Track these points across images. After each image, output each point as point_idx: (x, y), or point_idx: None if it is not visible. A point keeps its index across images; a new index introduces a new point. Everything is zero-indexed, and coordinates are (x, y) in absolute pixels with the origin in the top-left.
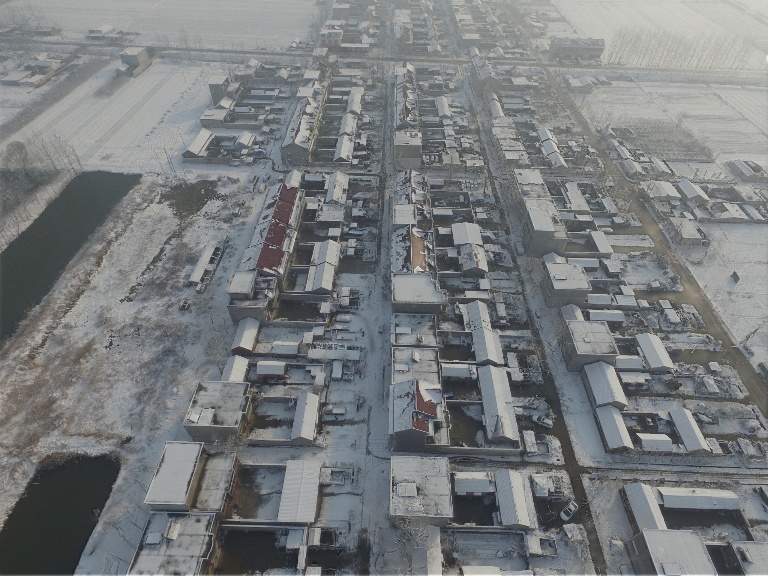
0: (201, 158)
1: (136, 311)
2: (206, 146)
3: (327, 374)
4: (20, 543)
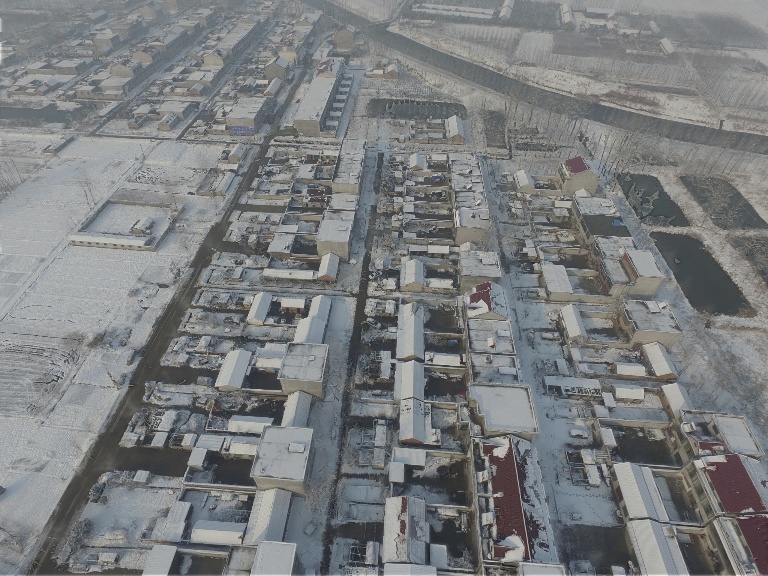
0: None
1: None
2: None
3: (571, 370)
4: (716, 282)
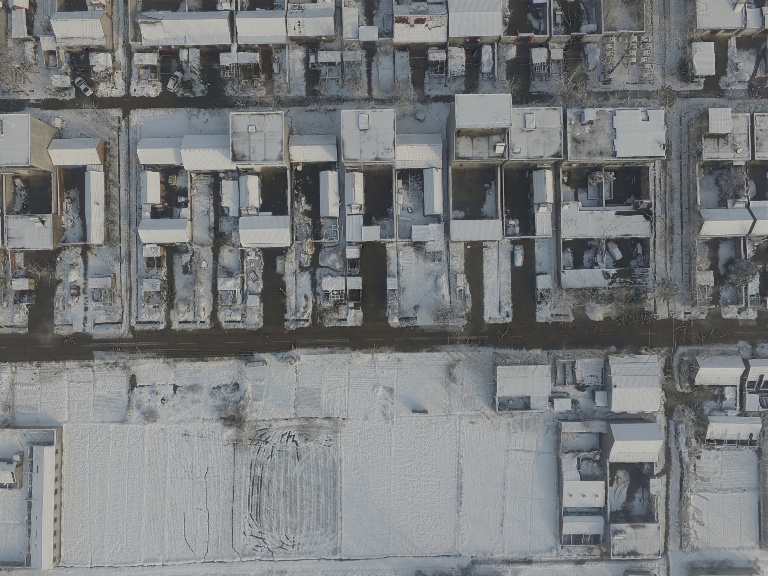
0: None
1: None
2: None
3: None
4: None
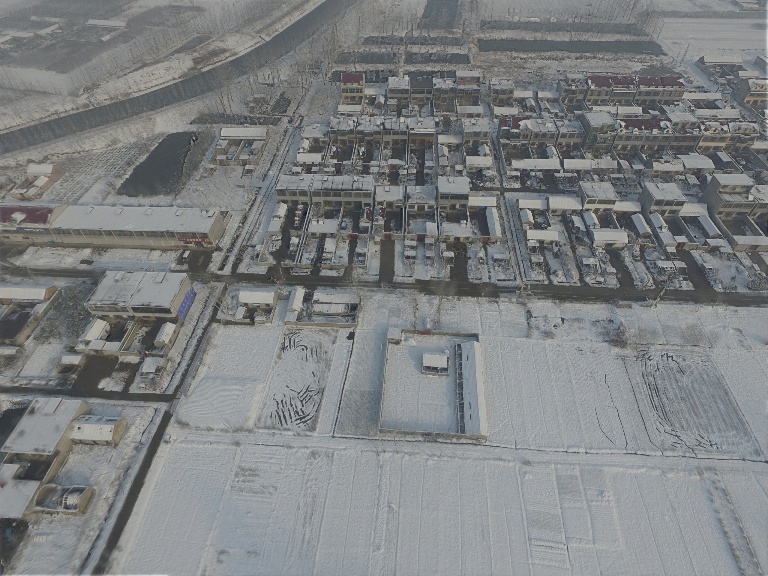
0: (703, 65)
1: (552, 73)
2: (721, 64)
3: None
4: None
